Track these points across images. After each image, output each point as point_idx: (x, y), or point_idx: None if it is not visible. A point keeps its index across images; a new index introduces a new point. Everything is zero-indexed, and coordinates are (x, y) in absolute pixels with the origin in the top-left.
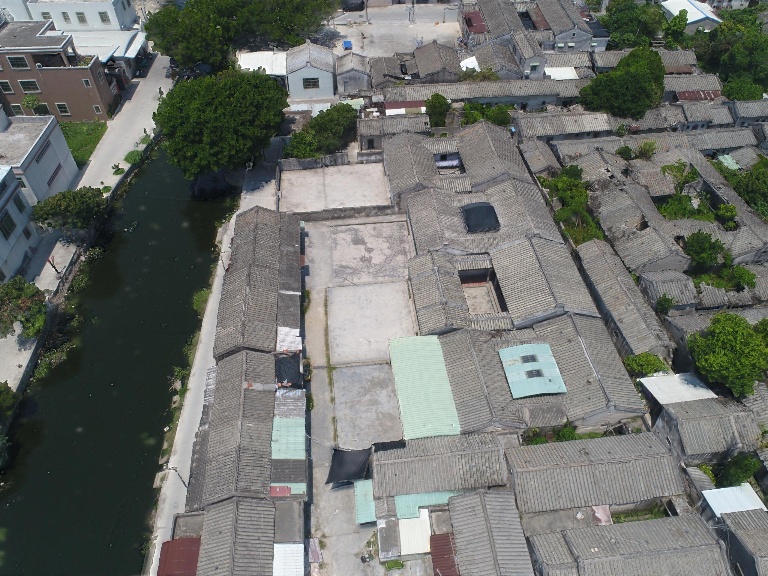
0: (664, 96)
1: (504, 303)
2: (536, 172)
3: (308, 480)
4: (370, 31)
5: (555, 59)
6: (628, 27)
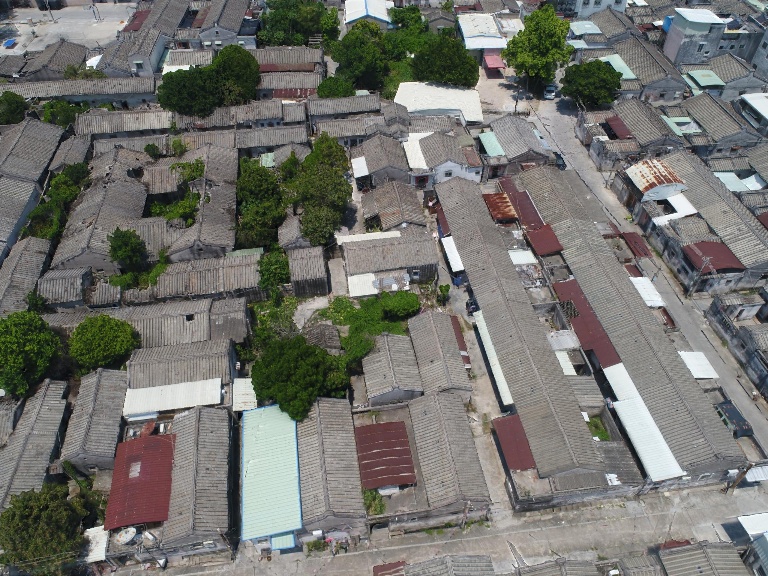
0: (268, 94)
1: None
2: (52, 170)
3: None
4: (49, 30)
5: (178, 57)
6: (280, 25)
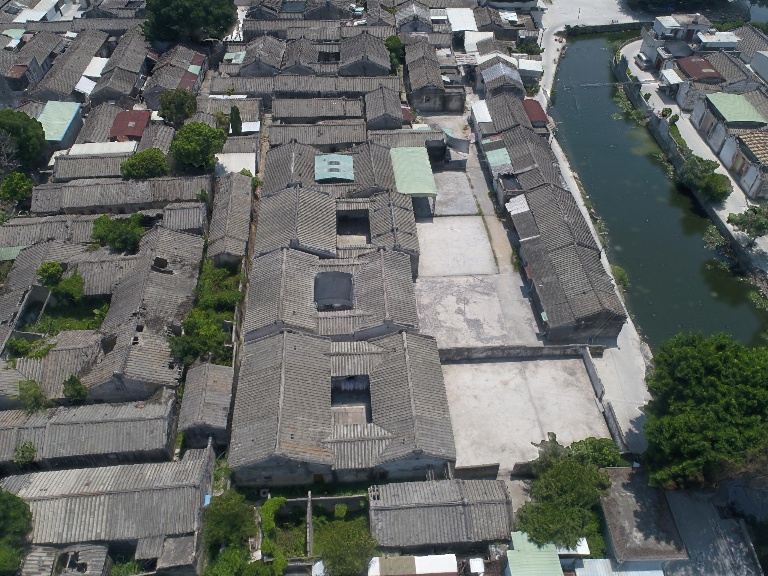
0: None
1: None
2: None
3: (482, 162)
4: None
5: None
6: None
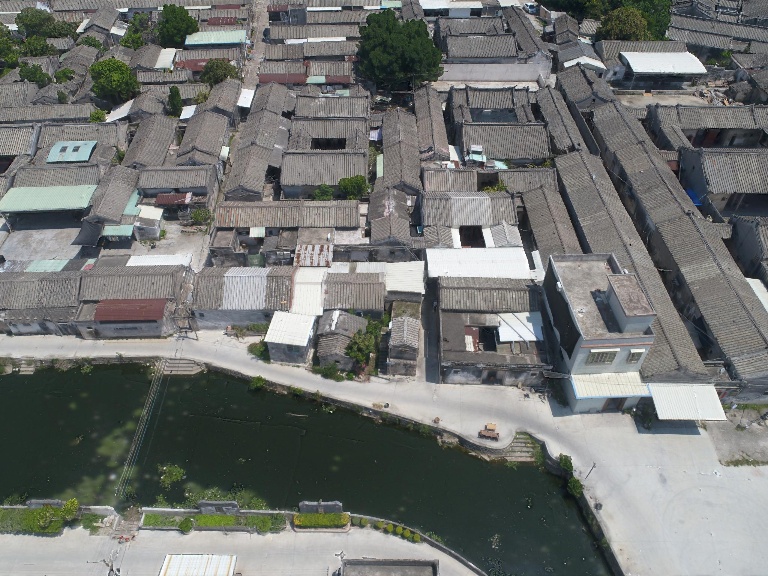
0: None
1: (0, 172)
2: None
3: None
4: None
5: None
6: None
